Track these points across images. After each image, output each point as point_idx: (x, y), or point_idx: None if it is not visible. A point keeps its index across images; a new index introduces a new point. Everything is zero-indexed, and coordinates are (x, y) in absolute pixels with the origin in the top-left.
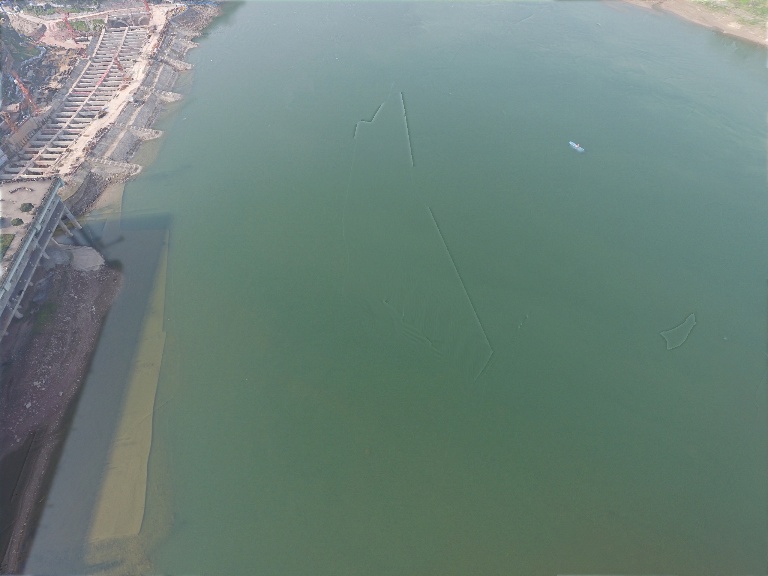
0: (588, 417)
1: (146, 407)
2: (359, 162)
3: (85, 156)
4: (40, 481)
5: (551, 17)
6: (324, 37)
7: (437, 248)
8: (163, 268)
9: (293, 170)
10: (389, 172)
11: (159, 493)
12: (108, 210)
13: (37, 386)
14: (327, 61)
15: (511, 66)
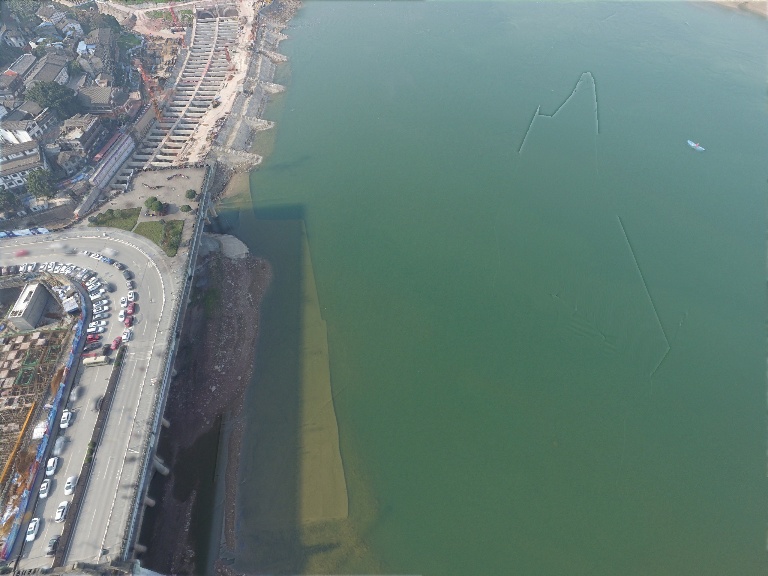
0: (761, 416)
1: (324, 394)
2: (531, 156)
3: (210, 145)
4: (238, 463)
5: (635, 15)
6: (412, 31)
7: (618, 243)
8: (308, 257)
9: (428, 163)
10: (569, 167)
11: (358, 478)
12: (239, 199)
13: (218, 370)
14: (422, 55)
15: (607, 64)
